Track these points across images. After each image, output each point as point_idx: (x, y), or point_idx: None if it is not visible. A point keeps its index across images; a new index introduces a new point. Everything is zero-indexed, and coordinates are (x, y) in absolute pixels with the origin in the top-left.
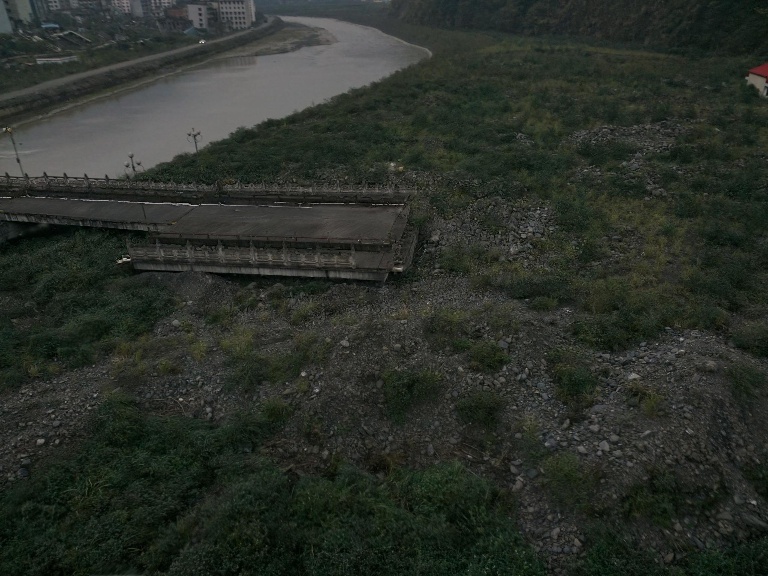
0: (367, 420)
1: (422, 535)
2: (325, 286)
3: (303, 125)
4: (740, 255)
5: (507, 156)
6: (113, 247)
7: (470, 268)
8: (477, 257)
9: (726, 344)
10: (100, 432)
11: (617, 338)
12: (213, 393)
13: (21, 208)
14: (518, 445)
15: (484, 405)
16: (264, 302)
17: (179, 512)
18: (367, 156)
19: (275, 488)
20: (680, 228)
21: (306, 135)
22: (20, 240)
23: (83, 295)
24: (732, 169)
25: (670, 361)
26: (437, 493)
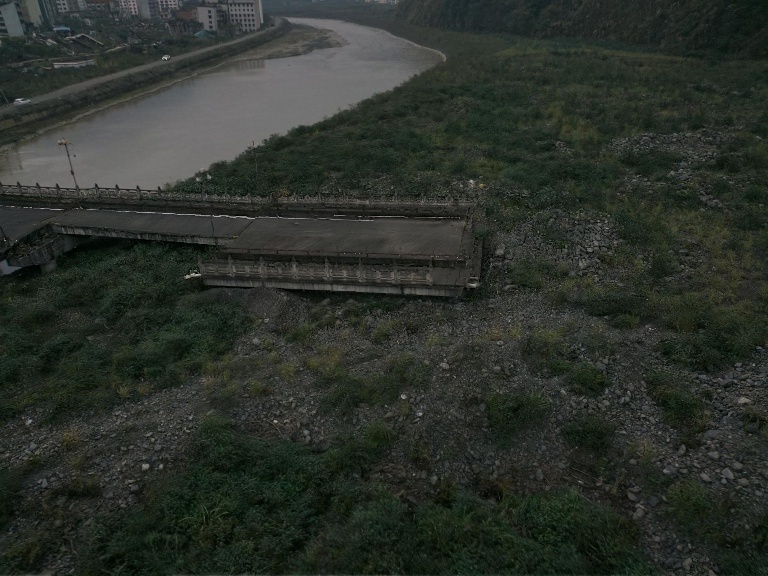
0: (472, 444)
1: (556, 567)
2: (399, 302)
3: (335, 132)
4: None
5: (553, 165)
6: (174, 261)
7: (542, 284)
8: (546, 272)
9: None
10: (202, 456)
11: (712, 359)
12: (309, 415)
13: (77, 221)
14: (634, 471)
15: (592, 429)
16: (341, 319)
17: (303, 542)
18: (408, 165)
19: (399, 517)
20: (745, 241)
21: (342, 143)
22: (75, 253)
23: (154, 311)
24: None
25: None
26: (561, 522)
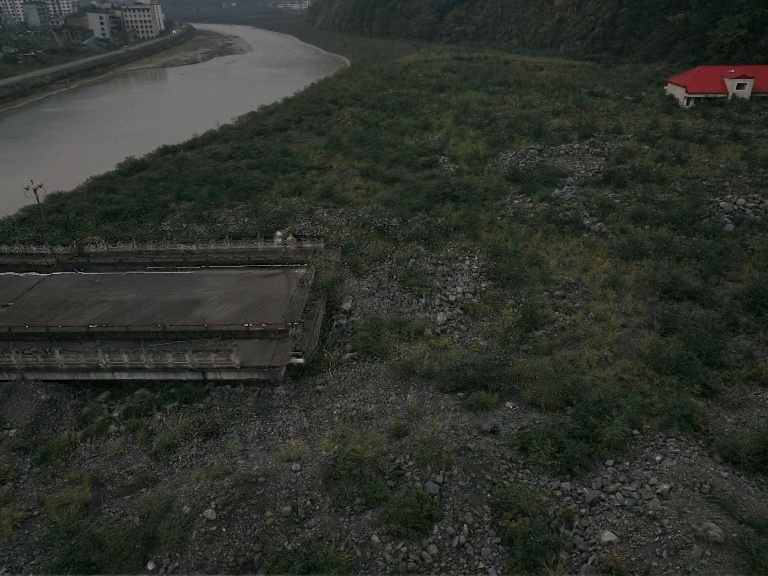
0: None
1: None
2: (204, 389)
3: (203, 151)
4: (701, 313)
5: (429, 187)
6: None
7: (389, 349)
8: (398, 331)
9: (711, 457)
10: None
11: (577, 458)
12: None
13: None
14: None
15: None
16: (118, 422)
17: None
18: (272, 190)
19: None
20: (627, 276)
21: (204, 165)
22: None
23: None
24: (670, 194)
25: (654, 513)
26: None
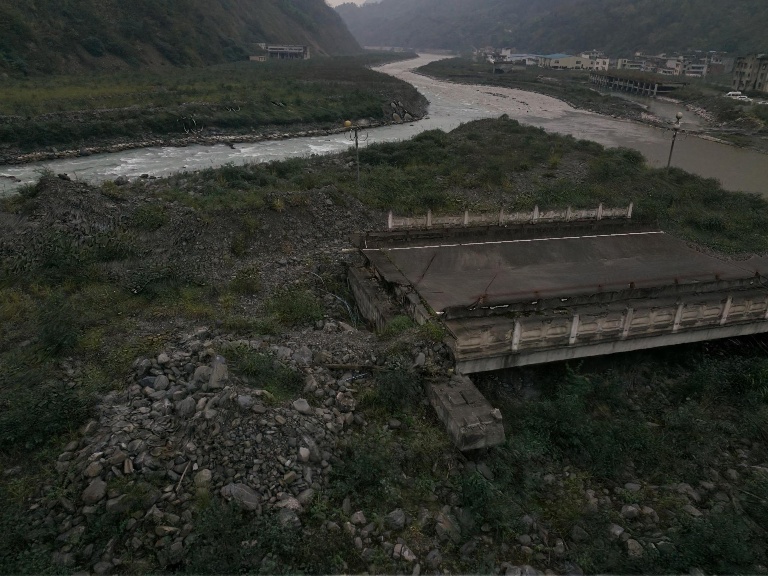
0: None
1: None
2: None
3: None
4: None
5: None
6: None
7: None
8: None
9: None
10: None
11: None
12: None
13: None
14: None
15: None
16: None
17: None
18: None
19: None
20: None
21: None
22: None
23: None
24: None
25: None
26: None
